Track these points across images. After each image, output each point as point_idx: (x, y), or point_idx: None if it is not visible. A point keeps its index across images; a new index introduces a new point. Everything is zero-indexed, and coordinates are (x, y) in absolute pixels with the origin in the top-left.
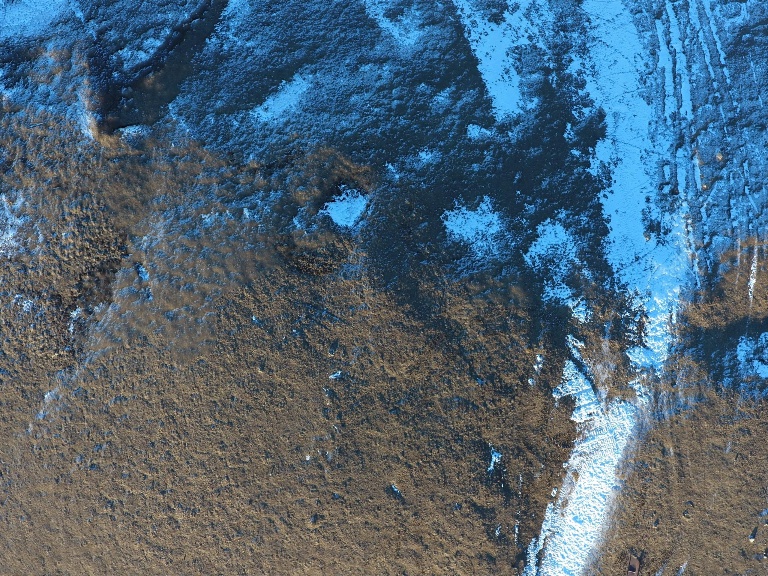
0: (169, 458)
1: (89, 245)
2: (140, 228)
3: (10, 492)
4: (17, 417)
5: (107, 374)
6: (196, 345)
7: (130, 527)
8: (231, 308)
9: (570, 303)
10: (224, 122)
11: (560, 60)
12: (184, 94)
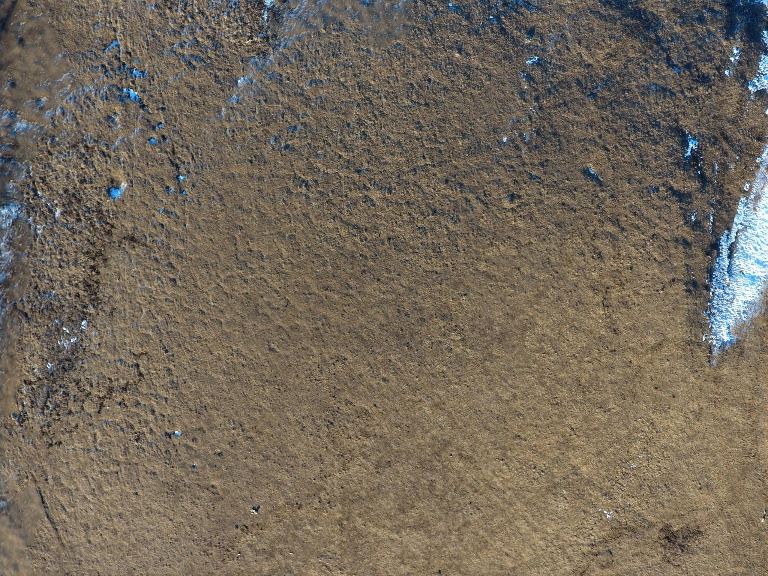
0: (365, 138)
1: None
2: None
3: (202, 174)
4: (210, 101)
5: (302, 58)
6: (393, 29)
7: (325, 205)
8: None
9: (765, 1)
10: None
11: None
12: None
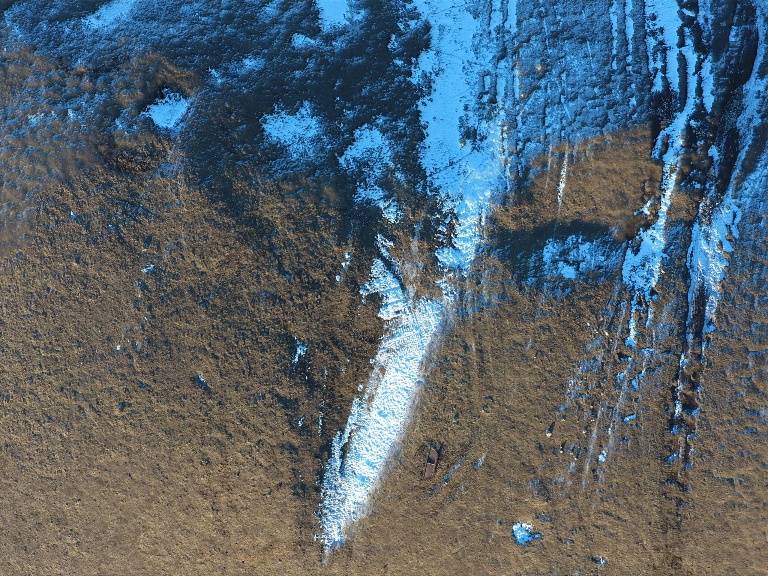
0: None
1: None
2: None
3: None
4: None
5: None
6: (15, 238)
7: None
8: (50, 203)
9: (381, 204)
10: (56, 28)
11: None
12: (20, 2)
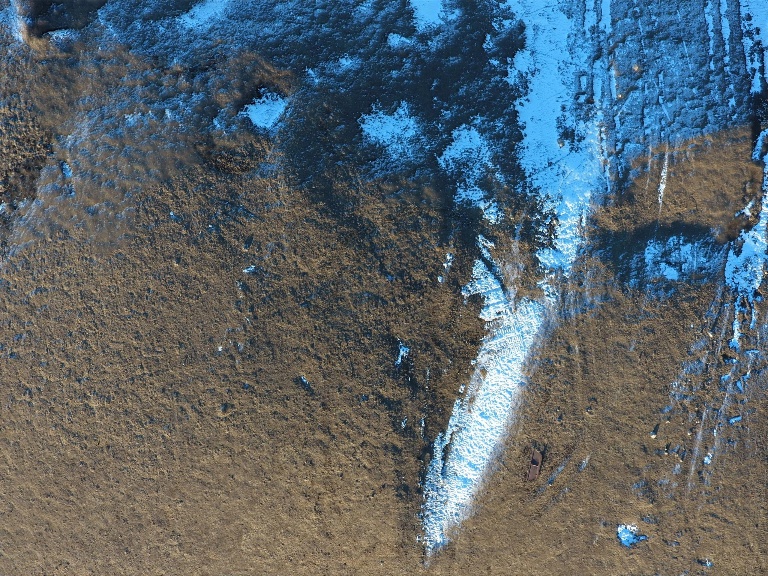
0: (86, 347)
1: (16, 143)
2: (65, 127)
3: None
4: None
5: (29, 266)
6: (115, 239)
7: (47, 413)
8: (150, 203)
9: (481, 205)
10: (150, 27)
11: None
12: (113, 1)
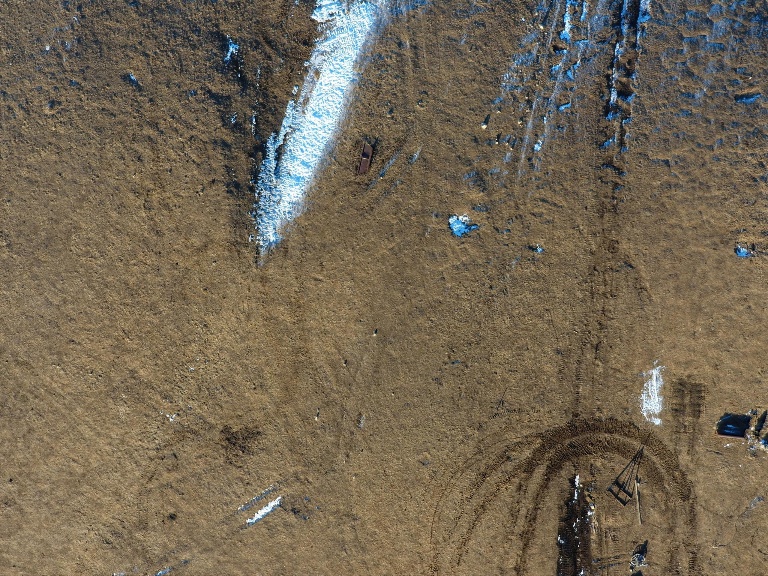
0: None
1: None
2: None
3: None
4: None
5: None
6: None
7: None
8: None
9: None
10: None
11: None
12: None
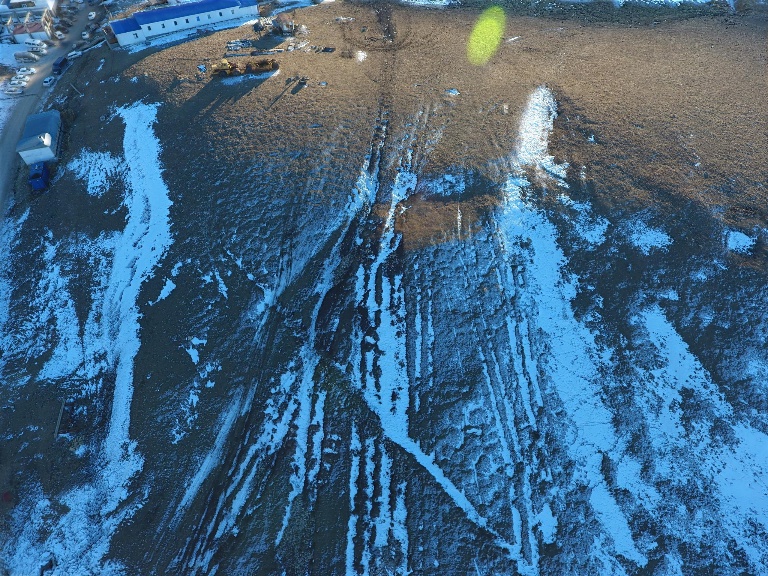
0: (764, 133)
1: None
2: None
3: None
4: None
5: None
6: None
7: (764, 112)
8: None
9: (572, 202)
10: None
11: (621, 358)
12: None
